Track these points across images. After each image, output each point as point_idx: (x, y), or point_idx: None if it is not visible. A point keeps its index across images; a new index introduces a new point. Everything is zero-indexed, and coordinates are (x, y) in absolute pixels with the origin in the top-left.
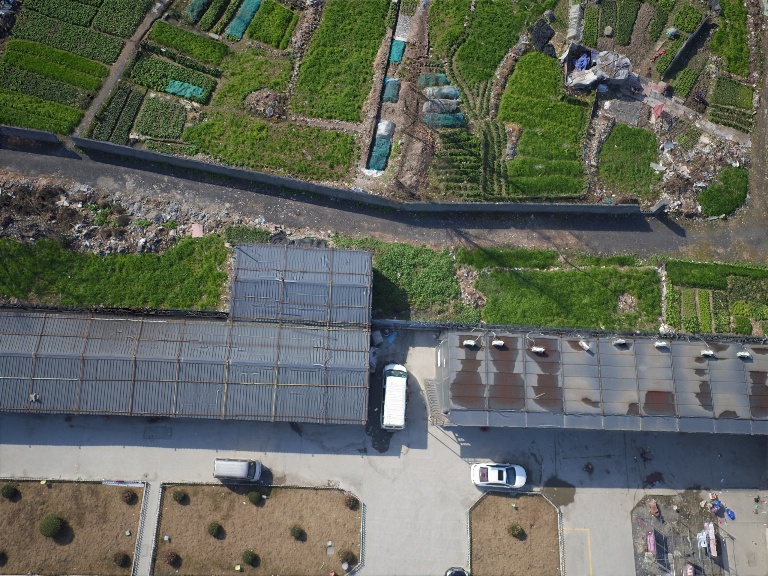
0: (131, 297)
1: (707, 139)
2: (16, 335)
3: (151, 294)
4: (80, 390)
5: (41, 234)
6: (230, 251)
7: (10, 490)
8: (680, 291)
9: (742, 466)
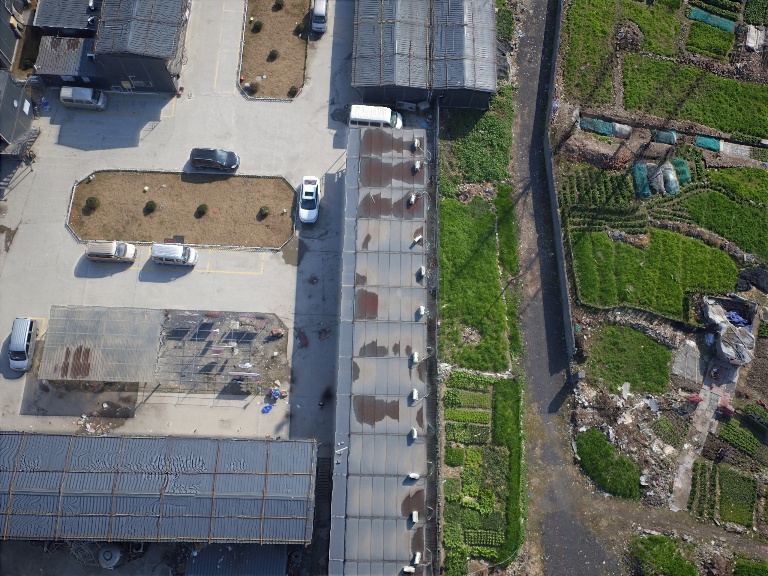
0: None
1: (670, 452)
2: None
3: None
4: None
5: None
6: None
7: None
8: (487, 391)
9: (311, 430)
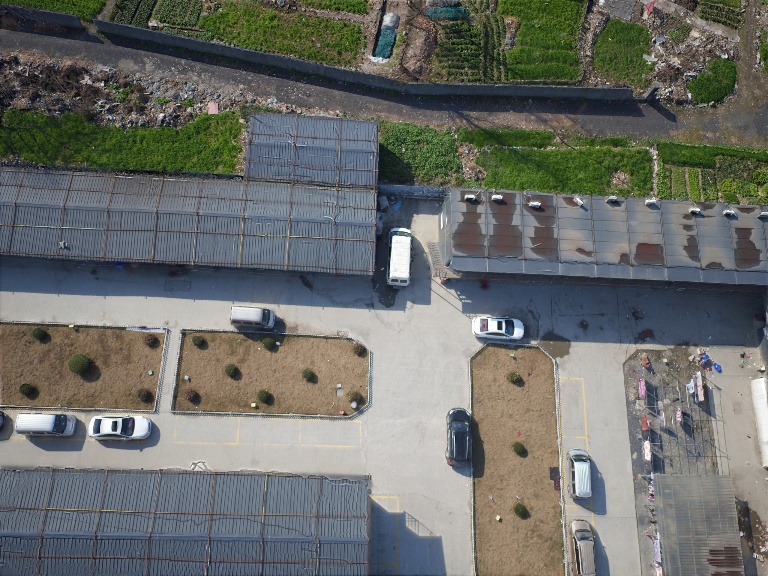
0: (151, 166)
1: (697, 33)
2: (46, 189)
3: (170, 163)
4: (106, 239)
5: (67, 108)
6: (244, 126)
7: (41, 332)
8: (671, 169)
9: (729, 326)
